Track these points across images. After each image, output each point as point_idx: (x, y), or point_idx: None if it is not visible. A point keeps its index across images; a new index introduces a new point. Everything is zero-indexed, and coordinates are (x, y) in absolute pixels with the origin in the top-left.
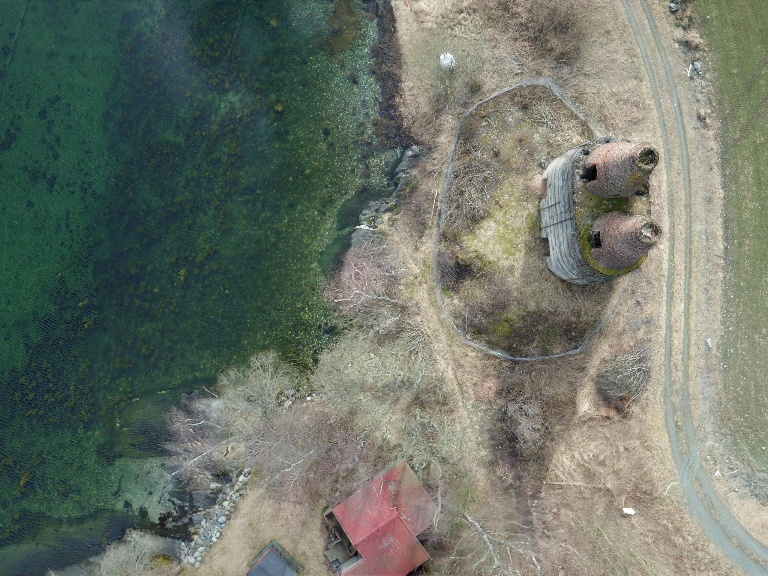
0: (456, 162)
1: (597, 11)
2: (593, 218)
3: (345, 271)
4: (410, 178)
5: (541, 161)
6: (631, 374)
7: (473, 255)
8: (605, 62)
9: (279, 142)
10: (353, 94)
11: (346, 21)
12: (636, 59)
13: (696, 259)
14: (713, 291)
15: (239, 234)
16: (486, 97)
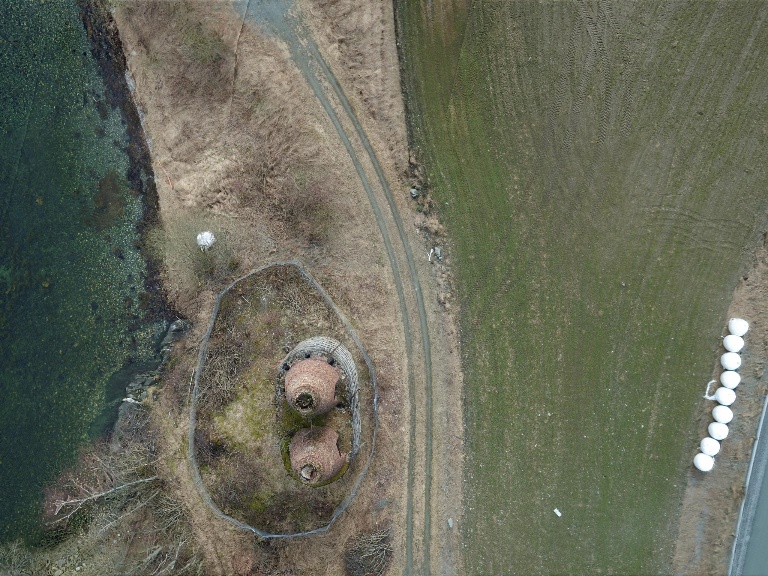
0: (211, 342)
1: (342, 196)
2: (292, 433)
3: (113, 443)
4: (171, 354)
5: (285, 346)
6: (374, 554)
7: (223, 436)
8: (350, 246)
9: (49, 316)
10: (120, 269)
11: (111, 198)
12: (378, 244)
13: (437, 441)
14: (454, 472)
15: (11, 406)
16: (244, 274)
